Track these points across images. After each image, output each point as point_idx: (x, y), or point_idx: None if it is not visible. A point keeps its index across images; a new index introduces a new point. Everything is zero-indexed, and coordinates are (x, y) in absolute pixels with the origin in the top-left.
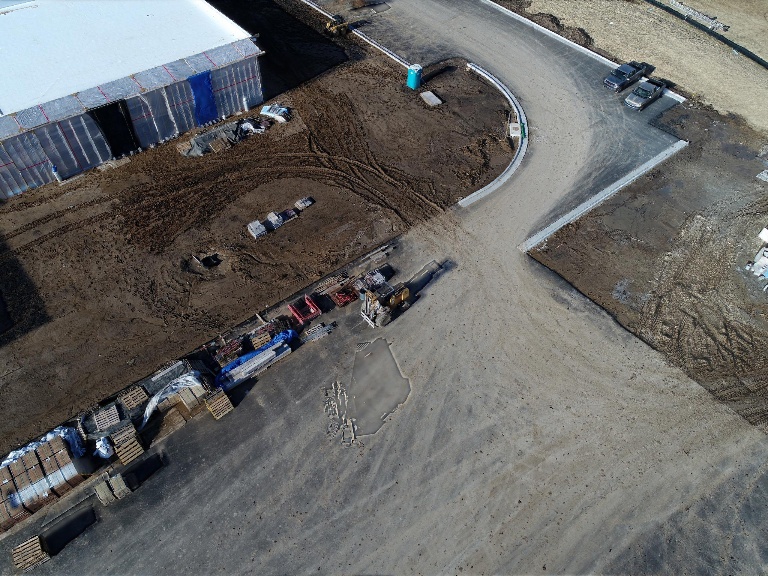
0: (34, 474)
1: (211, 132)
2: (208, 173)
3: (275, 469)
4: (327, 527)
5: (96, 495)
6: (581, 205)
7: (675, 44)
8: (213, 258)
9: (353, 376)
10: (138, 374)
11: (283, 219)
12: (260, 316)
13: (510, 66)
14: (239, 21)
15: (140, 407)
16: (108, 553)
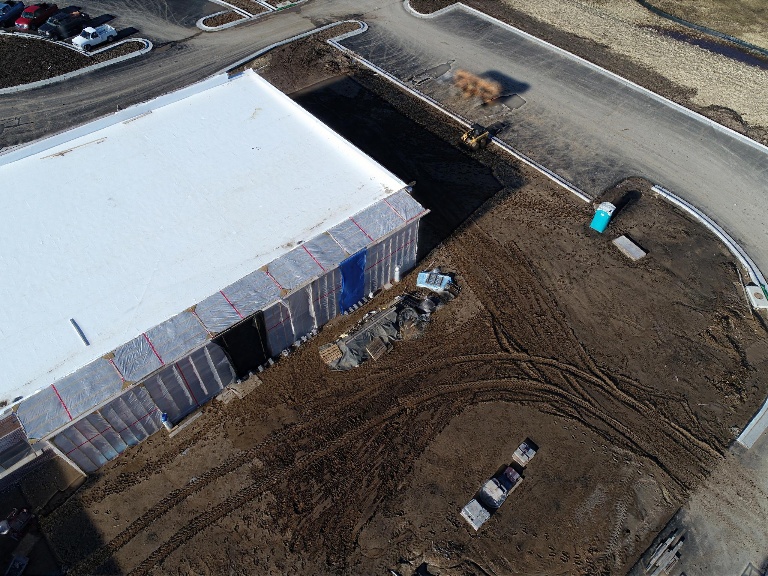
0: None
1: (366, 329)
2: (373, 399)
3: None
4: None
5: None
6: None
7: None
8: (421, 572)
9: None
10: None
11: (506, 489)
12: None
13: (707, 189)
14: (347, 130)
15: None
16: None
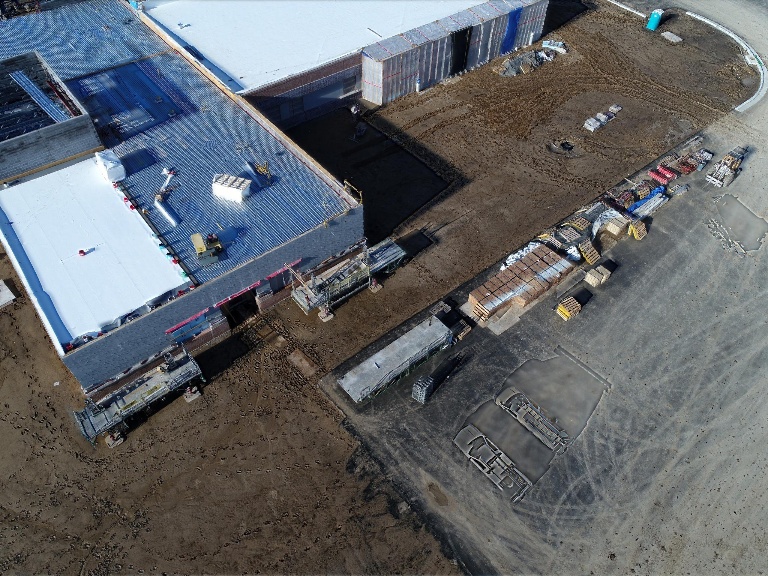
0: (542, 265)
1: (519, 58)
2: (527, 88)
3: (700, 269)
4: (757, 300)
5: (583, 281)
6: None
7: None
8: None
9: (722, 216)
10: (562, 214)
11: (607, 118)
12: (629, 180)
13: (723, 14)
14: None
15: (588, 229)
16: (614, 312)
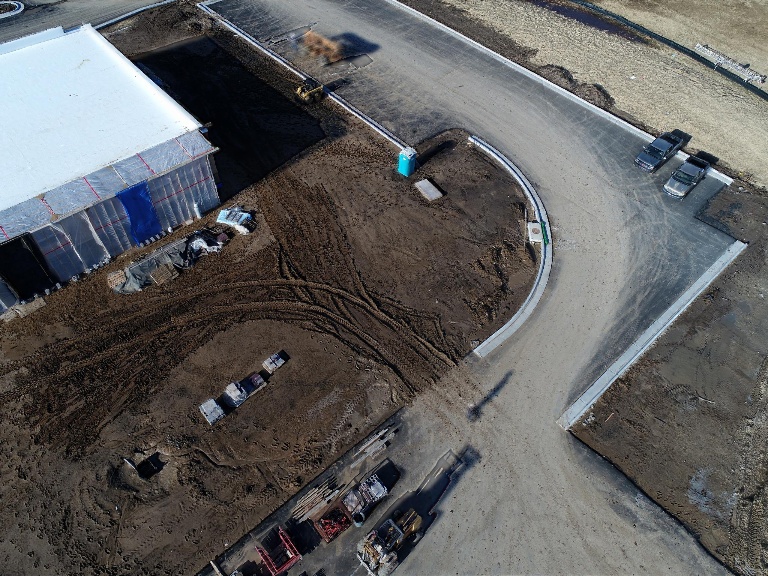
0: None
1: (152, 257)
2: (148, 318)
3: None
4: None
5: None
6: (630, 348)
7: (711, 105)
8: (153, 460)
9: None
10: None
11: (247, 391)
12: (216, 566)
13: (520, 139)
14: (191, 85)
15: None
16: None
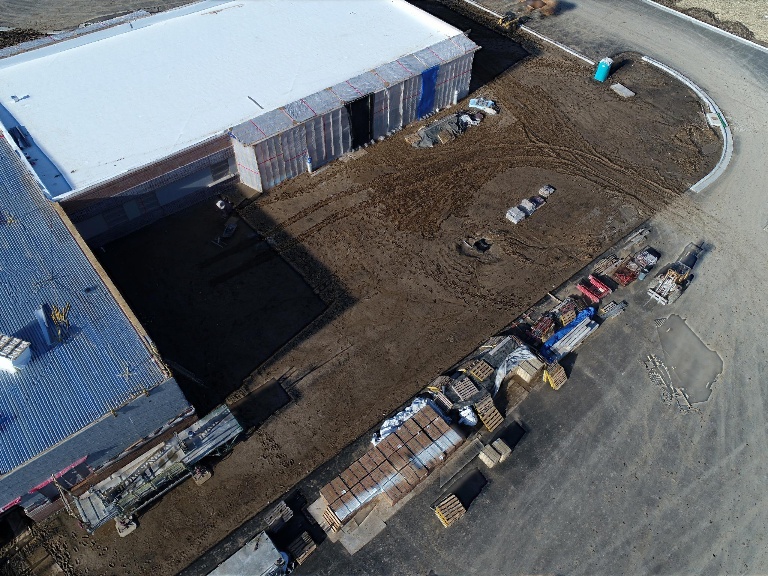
0: (422, 440)
1: (437, 124)
2: (444, 163)
3: (630, 434)
4: (701, 485)
5: (477, 459)
6: None
7: None
8: (482, 243)
9: (664, 349)
10: (463, 350)
11: (535, 205)
12: (553, 295)
13: (684, 59)
14: None
15: (490, 379)
16: (512, 510)
